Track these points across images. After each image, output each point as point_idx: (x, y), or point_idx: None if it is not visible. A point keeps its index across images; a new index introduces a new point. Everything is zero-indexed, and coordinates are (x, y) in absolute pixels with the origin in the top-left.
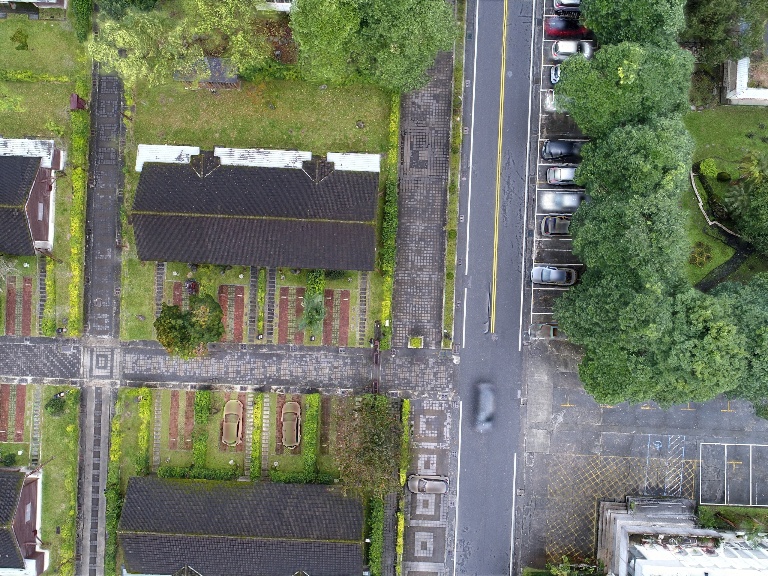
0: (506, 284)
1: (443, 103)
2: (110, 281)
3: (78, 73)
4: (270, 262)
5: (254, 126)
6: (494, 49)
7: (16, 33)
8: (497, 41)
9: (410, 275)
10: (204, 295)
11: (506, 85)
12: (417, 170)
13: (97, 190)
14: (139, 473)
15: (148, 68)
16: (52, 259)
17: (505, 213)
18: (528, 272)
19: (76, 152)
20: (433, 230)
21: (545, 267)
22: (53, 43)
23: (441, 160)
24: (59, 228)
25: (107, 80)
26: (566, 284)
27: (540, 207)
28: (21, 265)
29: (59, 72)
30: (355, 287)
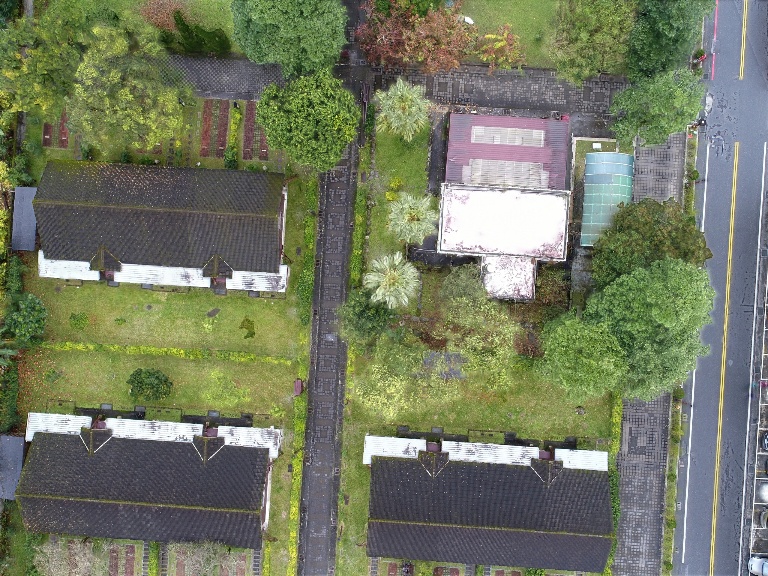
0: (723, 573)
1: (662, 390)
2: (324, 560)
3: (297, 351)
4: (499, 562)
5: (473, 409)
6: (715, 337)
7: (245, 323)
8: (718, 329)
9: (626, 561)
10: None
11: (726, 374)
12: (635, 456)
13: (313, 468)
14: None
15: (405, 397)
16: (270, 541)
17: (723, 502)
18: (745, 561)
19: (298, 436)
20: (650, 516)
21: (766, 561)
22: (273, 321)
23: (659, 447)
24: (274, 506)
25: (325, 358)
26: None
27: (758, 497)
28: None
29: (278, 350)
30: (571, 572)
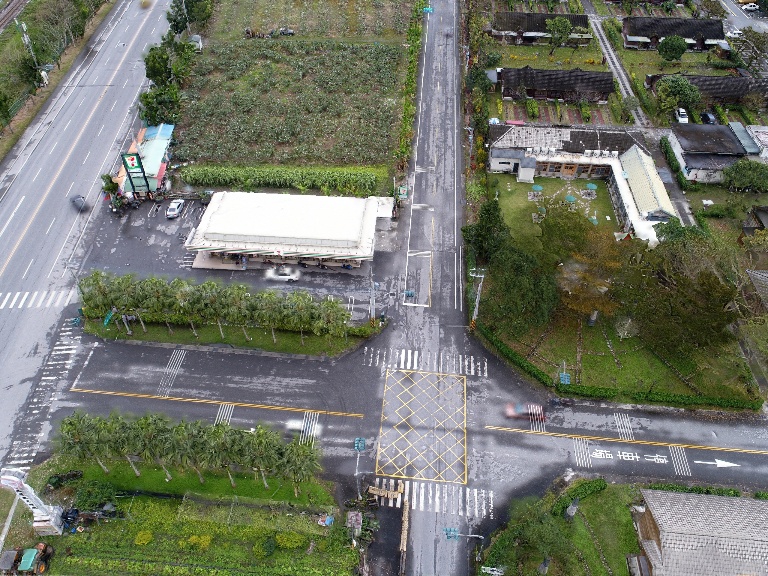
0: None
1: None
2: None
3: None
4: None
5: None
6: None
7: None
8: None
9: (698, 8)
10: (628, 4)
11: None
12: None
13: None
14: (620, 27)
15: None
16: None
17: None
18: (740, 8)
19: None
20: None
21: None
22: None
23: None
24: None
25: None
26: (756, 7)
27: (736, 0)
28: (557, 3)
29: None
30: None
